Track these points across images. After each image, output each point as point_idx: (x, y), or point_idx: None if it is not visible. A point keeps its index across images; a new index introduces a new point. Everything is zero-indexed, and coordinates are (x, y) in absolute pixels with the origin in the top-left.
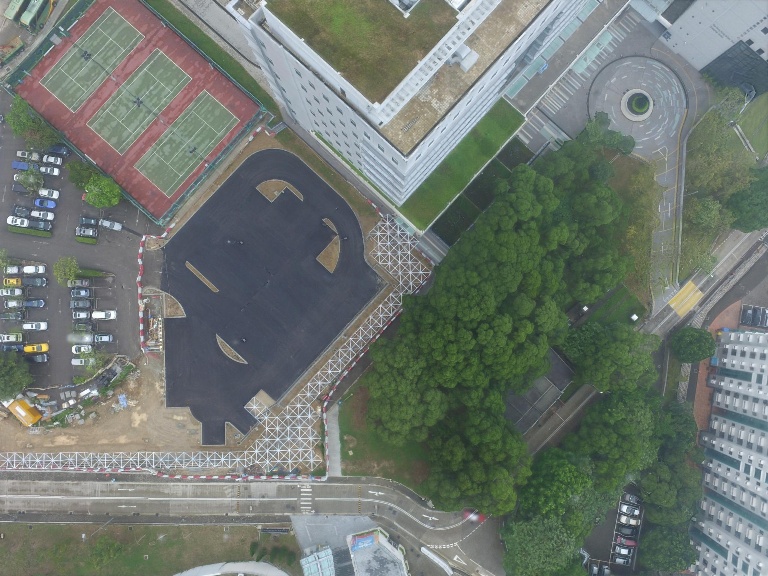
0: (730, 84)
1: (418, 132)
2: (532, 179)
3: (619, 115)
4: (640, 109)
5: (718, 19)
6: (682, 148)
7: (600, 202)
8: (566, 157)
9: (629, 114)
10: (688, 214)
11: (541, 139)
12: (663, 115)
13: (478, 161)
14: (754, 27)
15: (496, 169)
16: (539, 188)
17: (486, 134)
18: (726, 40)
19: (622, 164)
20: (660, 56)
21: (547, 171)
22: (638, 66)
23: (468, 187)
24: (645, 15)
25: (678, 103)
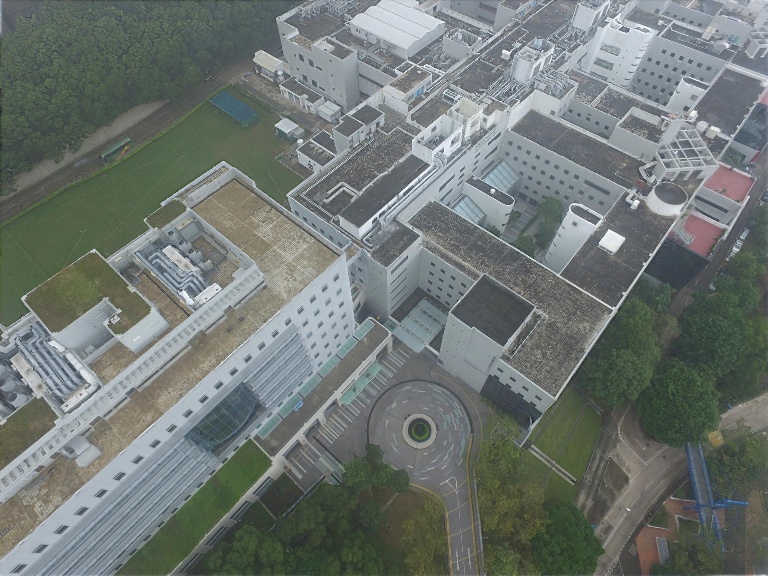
0: (508, 408)
1: (5, 546)
2: (250, 548)
3: (401, 442)
4: (420, 436)
5: (465, 355)
6: (472, 478)
7: (344, 571)
8: (318, 505)
9: (411, 441)
10: (482, 568)
11: (316, 473)
12: (448, 441)
13: (213, 516)
14: (491, 366)
15: (256, 514)
16: (261, 559)
17: (227, 482)
18: (480, 372)
19: (406, 500)
20: (439, 380)
21: (285, 529)
22: (418, 390)
23: (221, 539)
24: (412, 346)
25: (462, 427)
